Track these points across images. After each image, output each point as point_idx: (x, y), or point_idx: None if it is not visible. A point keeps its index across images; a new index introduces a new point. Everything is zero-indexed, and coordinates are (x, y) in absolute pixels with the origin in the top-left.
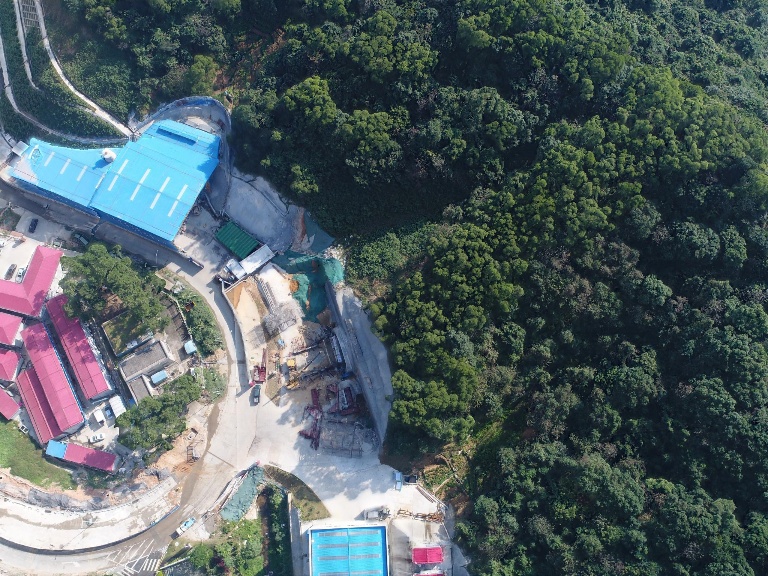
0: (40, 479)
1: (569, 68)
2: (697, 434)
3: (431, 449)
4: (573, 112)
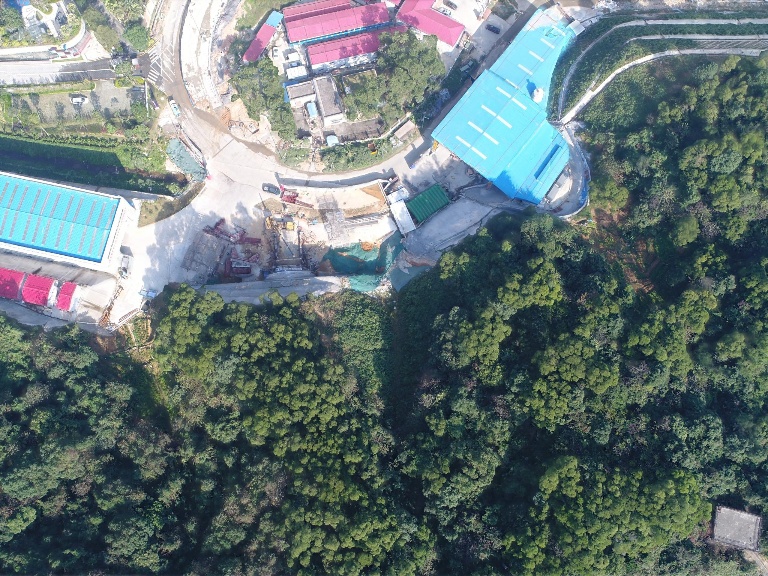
0: (252, 2)
1: (489, 575)
2: (49, 574)
3: (153, 322)
4: (446, 571)
